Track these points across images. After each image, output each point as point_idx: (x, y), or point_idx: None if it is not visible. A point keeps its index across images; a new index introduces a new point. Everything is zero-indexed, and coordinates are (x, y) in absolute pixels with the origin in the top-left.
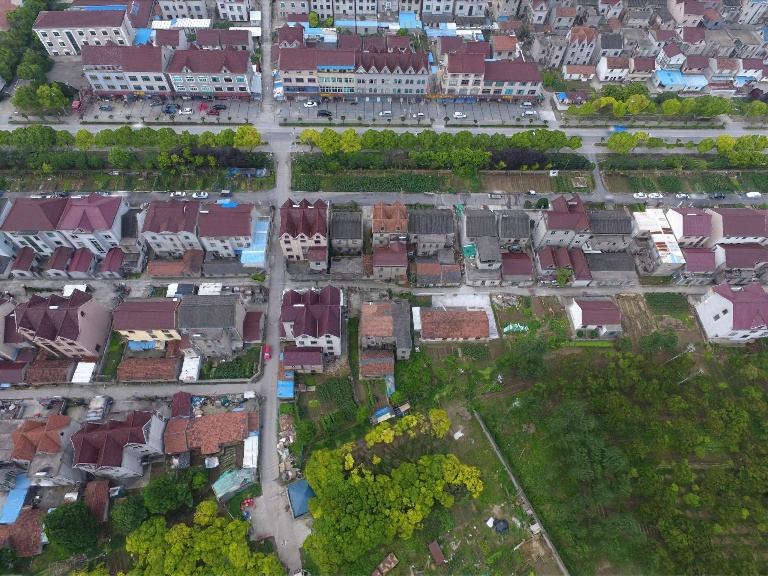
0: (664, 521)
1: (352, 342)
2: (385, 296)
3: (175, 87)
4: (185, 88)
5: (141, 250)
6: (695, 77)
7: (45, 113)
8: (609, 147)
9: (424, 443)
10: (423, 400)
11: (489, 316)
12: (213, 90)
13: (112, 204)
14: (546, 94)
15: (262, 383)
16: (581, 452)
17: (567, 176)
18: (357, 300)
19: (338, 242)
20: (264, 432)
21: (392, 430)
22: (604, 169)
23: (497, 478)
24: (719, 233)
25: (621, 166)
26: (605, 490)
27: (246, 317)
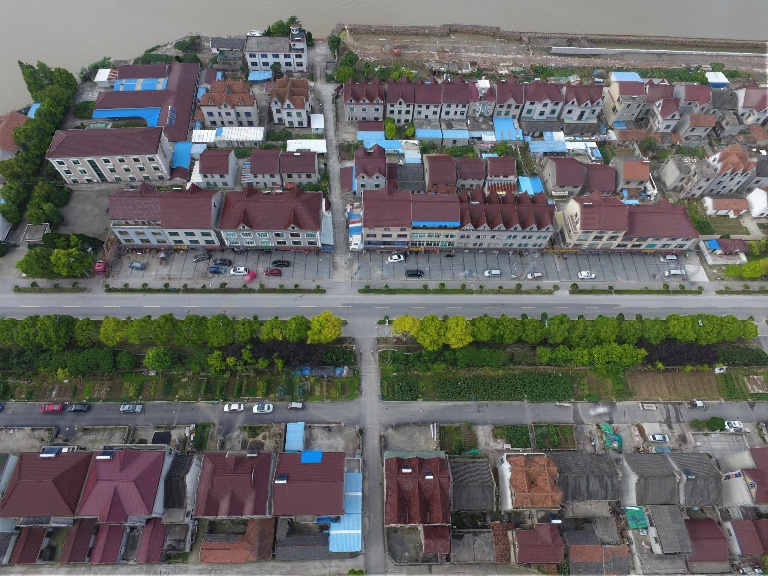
0: None
1: None
2: None
3: (226, 241)
4: (239, 242)
5: (190, 519)
6: None
7: (61, 274)
8: None
9: None
10: None
11: None
12: (274, 244)
13: (153, 469)
14: None
15: None
16: None
17: (737, 373)
18: None
19: None
20: None
21: None
22: None
23: None
24: None
25: None
26: None
27: None
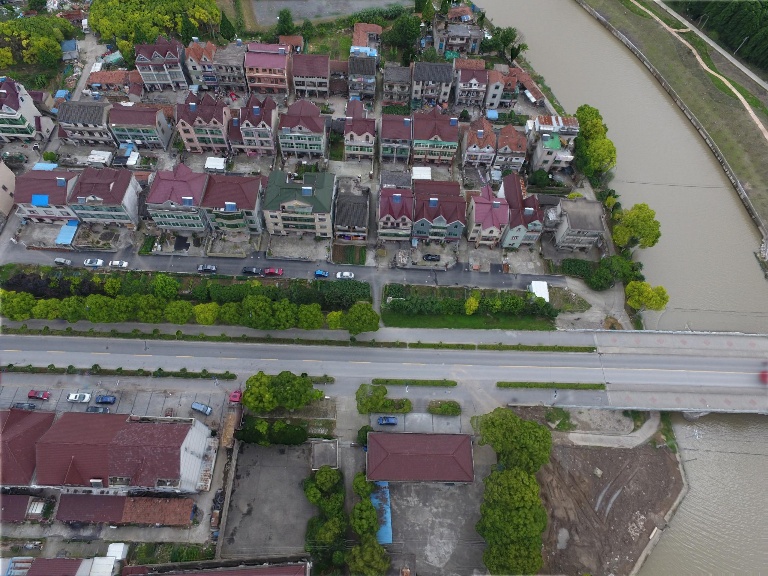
0: None
1: None
2: None
3: None
4: None
5: None
6: None
7: None
8: None
9: None
10: None
11: None
12: None
13: None
14: None
15: None
16: None
17: None
18: None
19: None
20: None
21: None
22: None
23: None
24: None
25: None
26: None
27: None
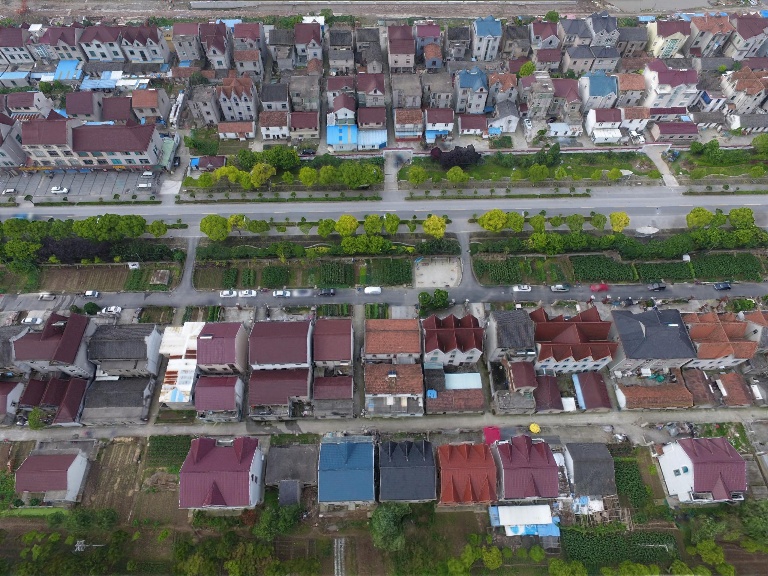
0: None
1: None
2: None
3: None
4: None
5: None
6: (375, 133)
7: None
8: None
9: None
10: None
11: None
12: None
13: None
14: (188, 158)
15: None
16: None
17: (151, 268)
18: None
19: None
20: None
21: None
22: (196, 259)
23: None
24: None
25: (212, 256)
26: None
27: None
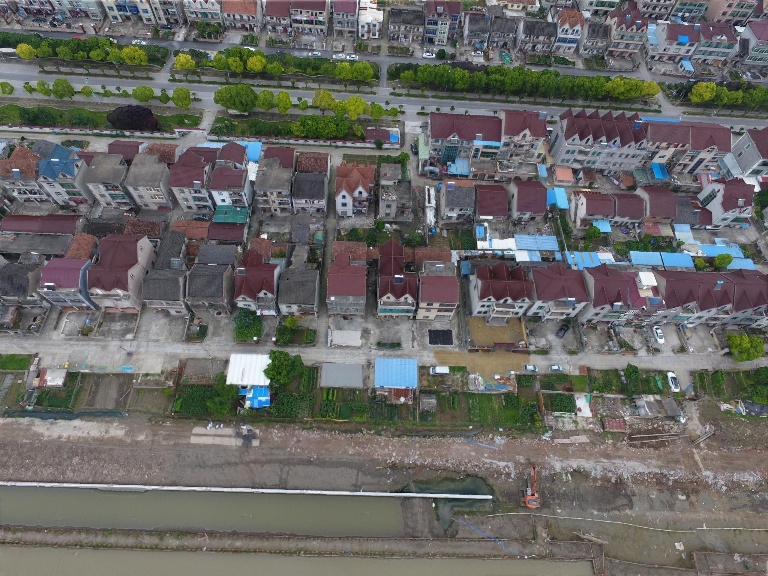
0: None
1: None
2: None
3: None
4: None
5: None
6: None
7: None
8: None
9: None
10: None
11: None
12: None
13: (760, 33)
14: None
15: None
16: None
17: None
18: None
19: None
20: None
21: None
22: None
23: None
24: None
25: None
26: None
27: (636, 7)
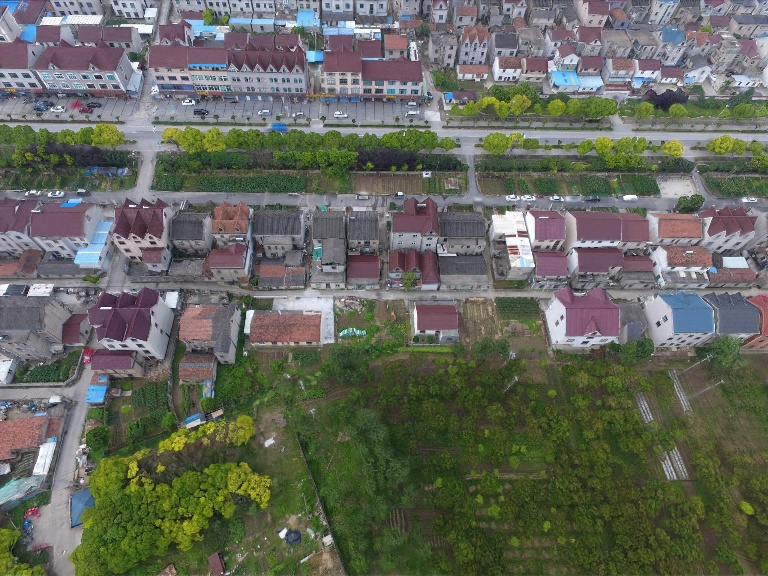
0: (456, 534)
1: (180, 346)
2: (224, 299)
3: (46, 84)
4: (56, 85)
5: None
6: (591, 78)
7: None
8: (485, 148)
9: (216, 451)
10: (241, 406)
11: (328, 320)
12: (86, 87)
13: None
14: (436, 94)
15: (77, 387)
16: (368, 462)
17: (441, 177)
18: (195, 302)
19: (181, 243)
20: (67, 438)
21: (185, 437)
22: (479, 170)
23: (300, 487)
24: (574, 237)
25: (495, 168)
26: (383, 502)
27: (69, 319)
